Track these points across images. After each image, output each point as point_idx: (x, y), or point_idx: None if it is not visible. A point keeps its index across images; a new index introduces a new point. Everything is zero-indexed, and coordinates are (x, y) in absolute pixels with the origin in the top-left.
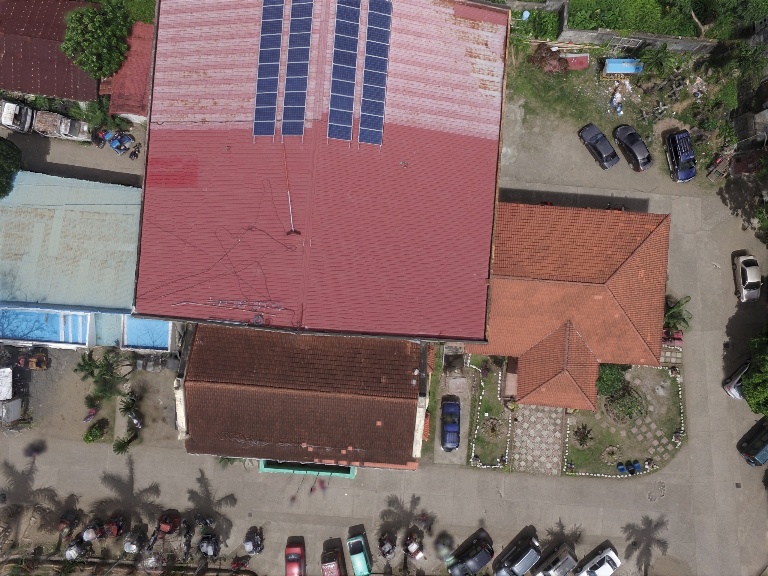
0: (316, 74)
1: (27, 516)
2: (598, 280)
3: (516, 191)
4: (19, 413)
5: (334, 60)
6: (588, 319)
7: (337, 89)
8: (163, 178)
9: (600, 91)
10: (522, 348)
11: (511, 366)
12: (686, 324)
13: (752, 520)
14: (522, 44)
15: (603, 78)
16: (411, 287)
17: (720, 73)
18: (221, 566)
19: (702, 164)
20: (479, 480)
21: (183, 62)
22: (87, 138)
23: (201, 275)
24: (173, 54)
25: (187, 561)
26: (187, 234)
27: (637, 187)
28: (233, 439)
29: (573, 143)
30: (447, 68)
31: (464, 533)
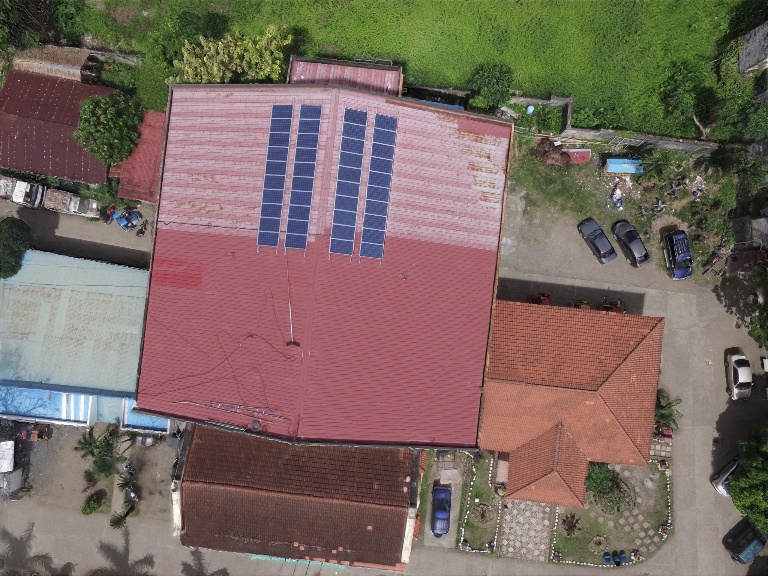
0: (321, 189)
1: None
2: (590, 387)
3: (514, 281)
4: (20, 482)
5: (339, 176)
6: (579, 422)
7: (340, 205)
8: (168, 277)
9: (601, 186)
10: (514, 445)
11: (503, 454)
12: (676, 426)
13: None
14: None
15: (604, 174)
16: (406, 396)
17: (720, 173)
18: None
19: (699, 262)
20: (467, 564)
21: (192, 165)
22: (95, 215)
23: (202, 376)
24: (182, 156)
25: None
26: (189, 334)
27: (634, 282)
28: (227, 535)
29: (572, 236)
30: (449, 181)
31: None
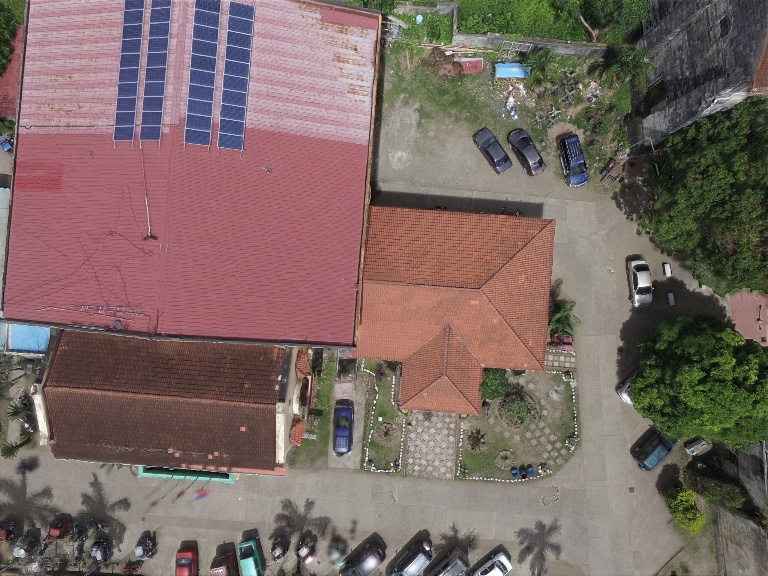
0: (174, 79)
1: None
2: (473, 285)
3: (411, 195)
4: None
5: (192, 65)
6: (467, 324)
7: (195, 94)
8: (30, 182)
9: (495, 95)
10: (405, 353)
11: None
12: (570, 329)
13: (645, 524)
14: (416, 48)
15: (497, 82)
16: (275, 292)
17: (614, 77)
18: (114, 571)
19: (596, 168)
20: (373, 484)
21: (50, 66)
22: None
23: (65, 280)
24: (41, 58)
25: (79, 566)
26: (52, 239)
27: (532, 191)
28: (99, 444)
29: (468, 147)
30: (313, 73)
31: (358, 537)
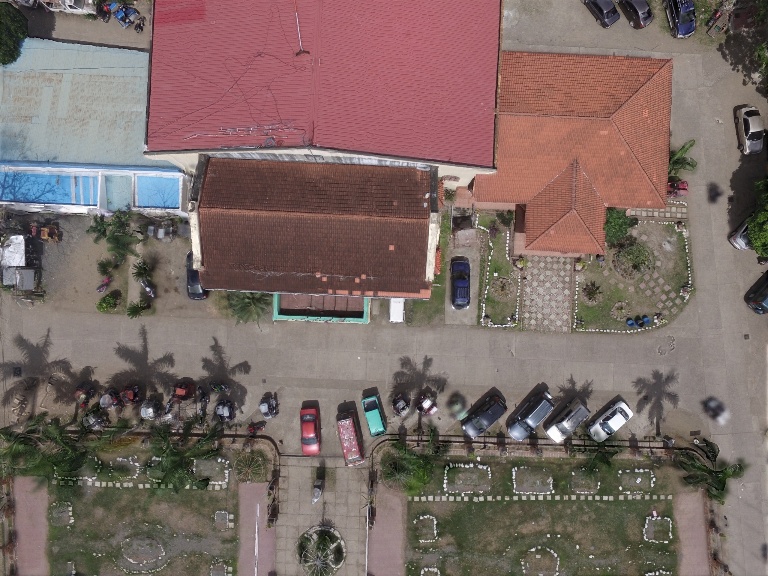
0: None
1: (43, 388)
2: (603, 114)
3: None
4: (32, 285)
5: None
6: (594, 158)
7: None
8: (171, 16)
9: None
10: (530, 193)
11: (519, 225)
12: (691, 167)
13: (761, 371)
14: None
15: None
16: (420, 112)
17: None
18: (237, 432)
19: (702, 20)
20: (490, 340)
21: None
22: (92, 10)
23: (212, 107)
24: None
25: (203, 428)
26: (196, 68)
27: (638, 46)
28: (248, 271)
29: (574, 4)
30: None
31: (477, 392)
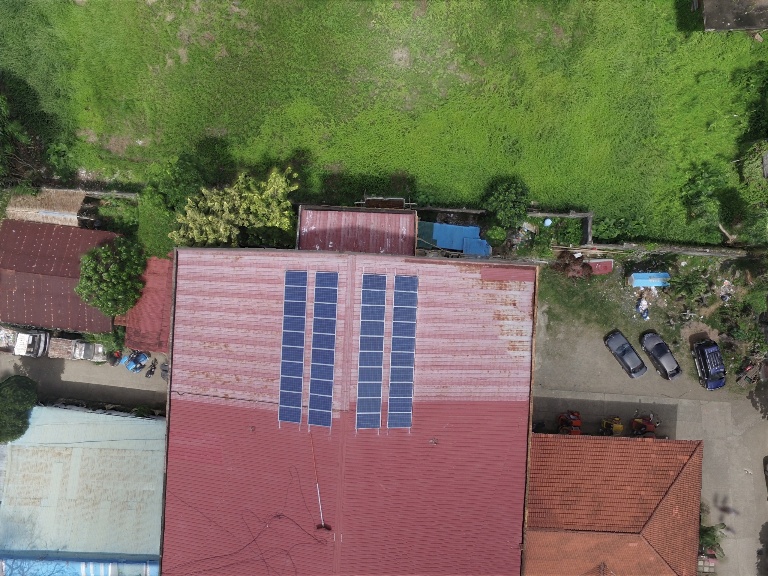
0: (342, 362)
1: None
2: (633, 529)
3: (541, 399)
4: None
5: (360, 347)
6: (622, 561)
7: (364, 376)
8: (186, 451)
9: (625, 296)
10: None
11: None
12: (721, 553)
13: None
14: None
15: (628, 285)
16: (444, 565)
17: (748, 276)
18: None
19: (731, 369)
20: None
21: (203, 332)
22: (102, 359)
23: (228, 557)
24: (192, 322)
25: None
26: (212, 512)
27: (665, 393)
28: None
29: (599, 349)
30: (475, 335)
31: None
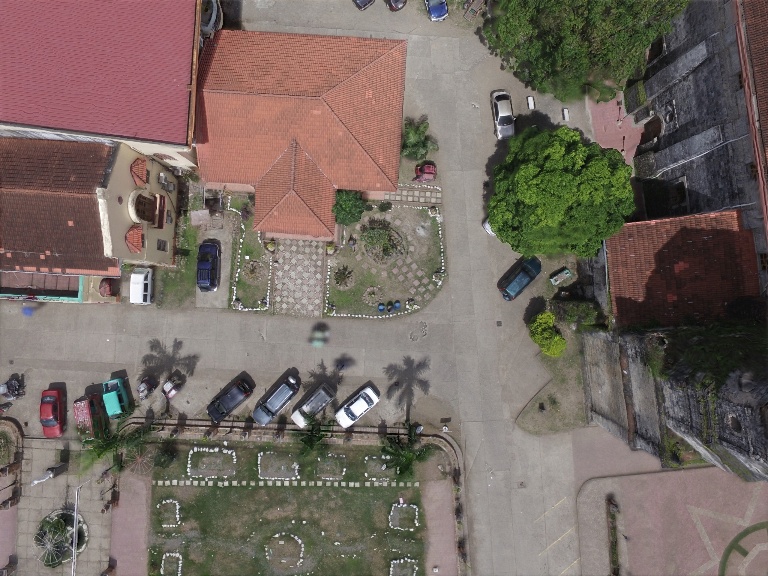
0: None
1: None
2: (314, 93)
3: None
4: None
5: None
6: (314, 138)
7: None
8: None
9: None
10: (257, 174)
11: None
12: (423, 149)
13: (513, 358)
14: None
15: None
16: (101, 86)
17: None
18: None
19: (458, 3)
20: (241, 323)
21: None
22: None
23: None
24: None
25: None
26: None
27: (396, 28)
28: None
29: None
30: None
31: (227, 376)
